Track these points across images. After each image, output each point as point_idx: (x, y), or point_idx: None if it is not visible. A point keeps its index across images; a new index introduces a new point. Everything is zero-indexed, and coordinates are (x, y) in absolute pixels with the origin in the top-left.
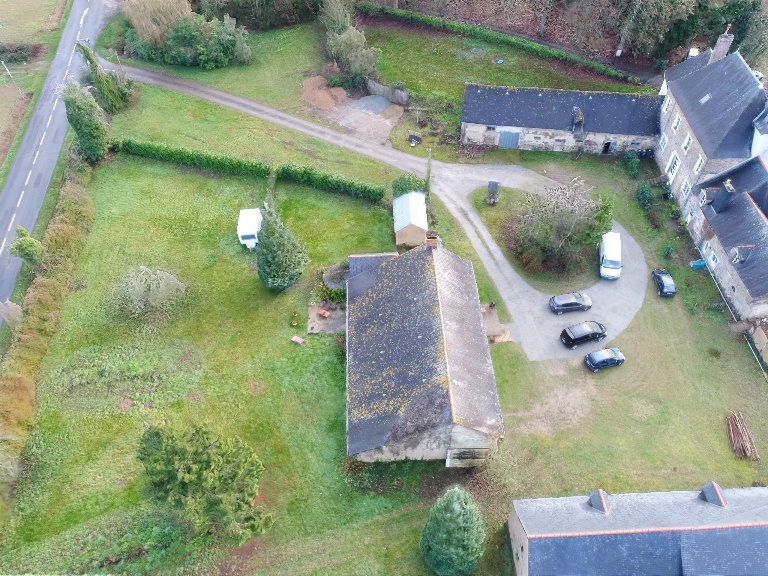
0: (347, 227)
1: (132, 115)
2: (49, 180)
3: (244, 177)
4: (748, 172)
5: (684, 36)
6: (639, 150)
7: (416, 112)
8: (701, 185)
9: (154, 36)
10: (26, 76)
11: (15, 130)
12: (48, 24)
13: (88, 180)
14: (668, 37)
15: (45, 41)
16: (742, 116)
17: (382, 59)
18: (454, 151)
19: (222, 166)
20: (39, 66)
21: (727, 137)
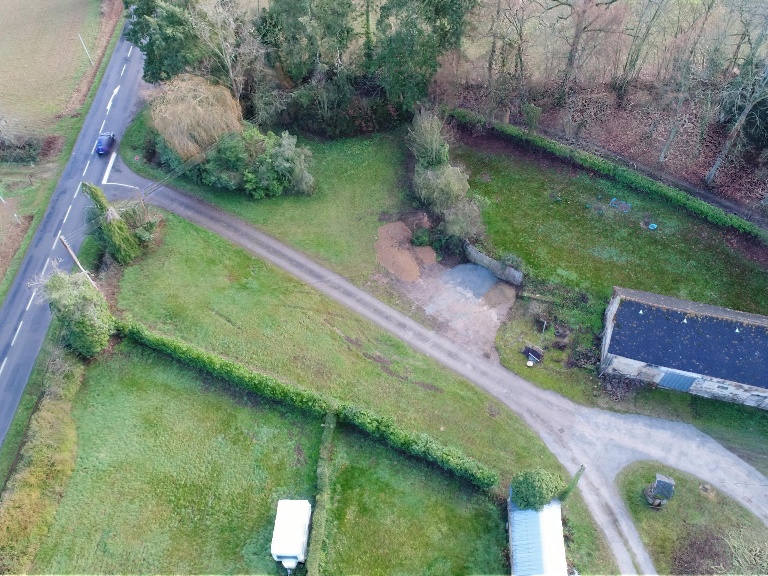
0: (436, 538)
1: (151, 269)
2: (27, 379)
3: (289, 410)
4: None
5: None
6: None
7: (536, 308)
8: None
9: (187, 169)
10: (29, 188)
11: (1, 278)
12: (69, 106)
13: (77, 388)
14: None
15: (61, 132)
16: None
17: None
18: (591, 383)
19: (260, 389)
20: (48, 171)
21: None
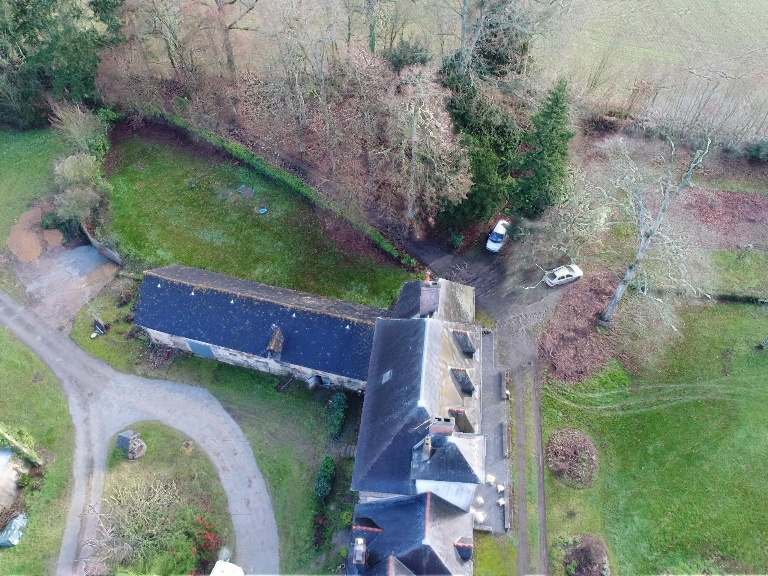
0: None
1: None
2: None
3: None
4: (410, 516)
5: (483, 209)
6: (359, 391)
7: (116, 285)
8: (364, 507)
9: None
10: None
11: None
12: None
13: None
14: (460, 209)
15: None
16: (396, 439)
17: (126, 191)
18: (138, 352)
19: None
20: None
21: (378, 463)
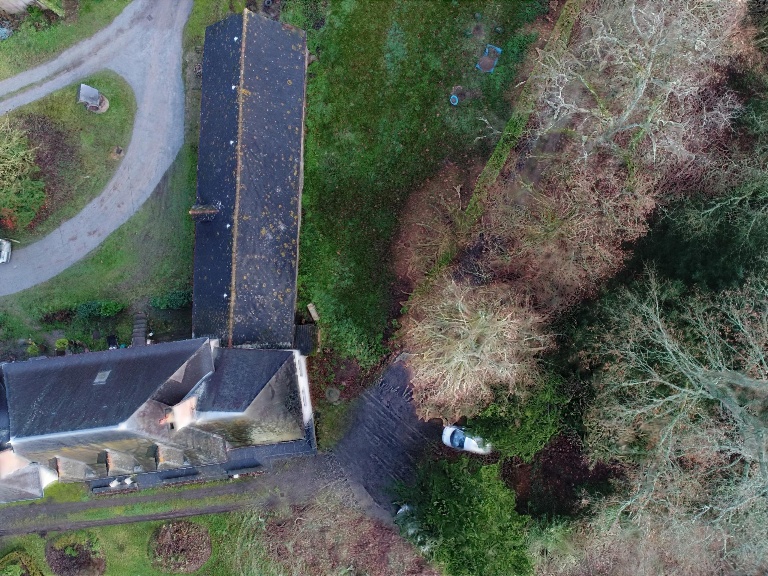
0: None
1: None
2: None
3: None
4: (6, 422)
5: None
6: None
7: None
8: None
9: None
10: None
11: None
12: None
13: None
14: None
15: None
16: None
17: None
18: None
19: None
20: None
21: None
